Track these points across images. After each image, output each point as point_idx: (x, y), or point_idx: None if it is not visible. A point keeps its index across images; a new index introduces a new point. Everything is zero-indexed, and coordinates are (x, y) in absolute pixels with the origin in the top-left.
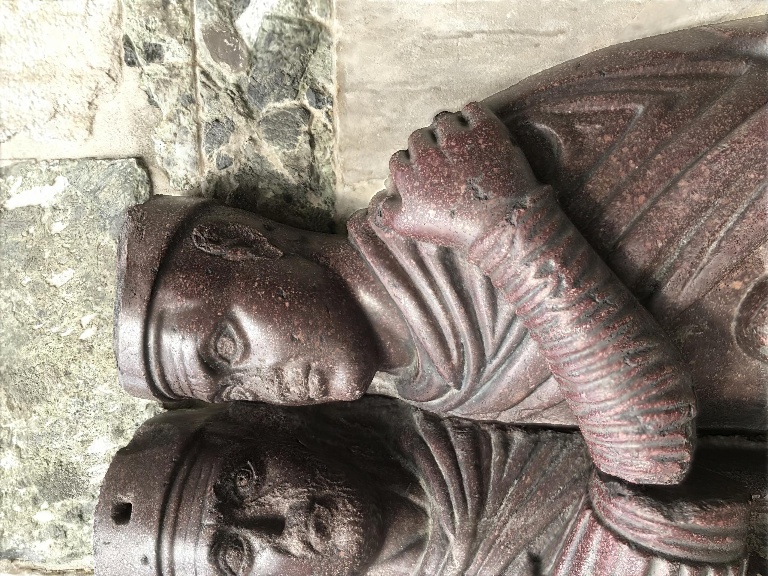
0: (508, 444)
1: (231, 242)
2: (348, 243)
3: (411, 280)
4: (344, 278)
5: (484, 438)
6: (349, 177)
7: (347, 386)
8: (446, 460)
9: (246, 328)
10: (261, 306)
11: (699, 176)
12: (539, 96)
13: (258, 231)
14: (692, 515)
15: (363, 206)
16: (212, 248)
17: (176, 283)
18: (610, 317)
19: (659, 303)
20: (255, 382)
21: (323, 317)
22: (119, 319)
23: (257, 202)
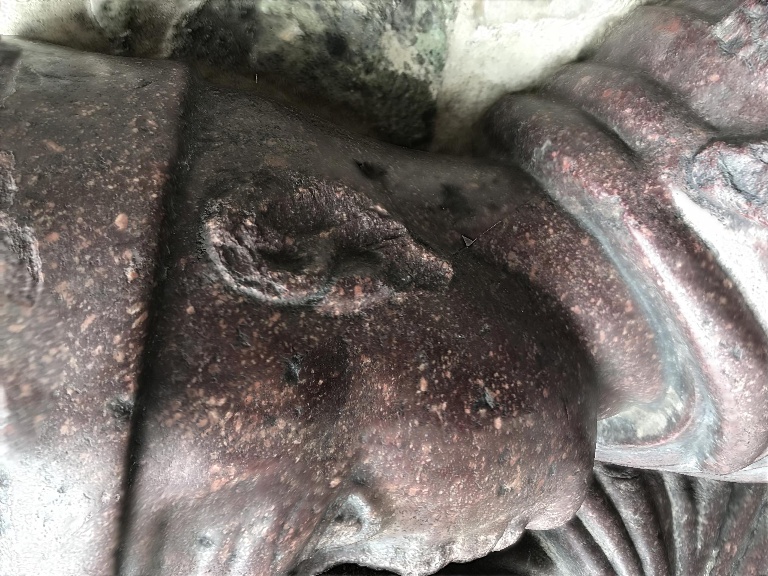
0: (692, 490)
1: (326, 254)
2: (558, 210)
3: (767, 340)
4: (566, 305)
5: (656, 484)
6: (499, 8)
7: (557, 525)
8: (613, 534)
9: (395, 494)
10: (442, 443)
11: None
12: None
13: (373, 199)
14: None
15: (502, 75)
16: (283, 287)
17: (198, 427)
18: None
19: None
20: (382, 568)
21: (559, 427)
22: (3, 555)
23: (255, 51)
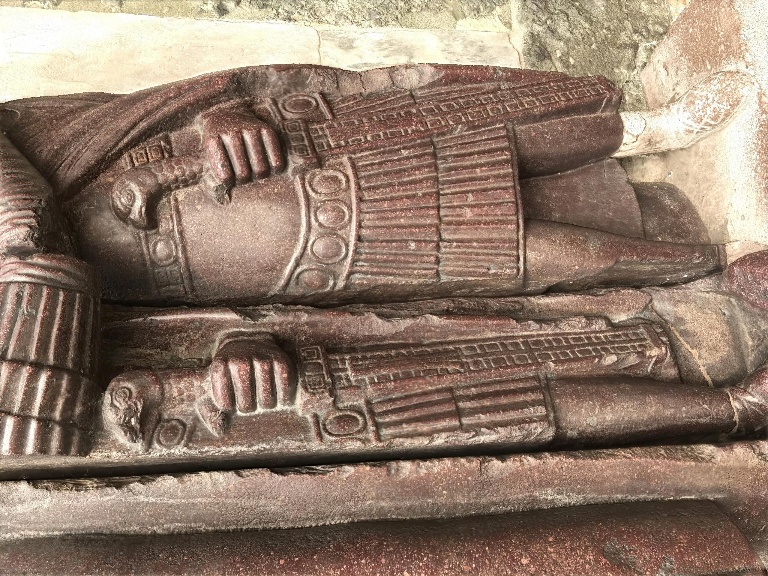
0: None
1: None
2: None
3: None
4: None
5: None
6: None
7: None
8: None
9: None
10: None
11: (80, 118)
12: (18, 102)
13: None
14: (36, 256)
15: None
16: None
17: None
18: (0, 157)
19: (55, 178)
20: None
21: None
22: None
23: None
